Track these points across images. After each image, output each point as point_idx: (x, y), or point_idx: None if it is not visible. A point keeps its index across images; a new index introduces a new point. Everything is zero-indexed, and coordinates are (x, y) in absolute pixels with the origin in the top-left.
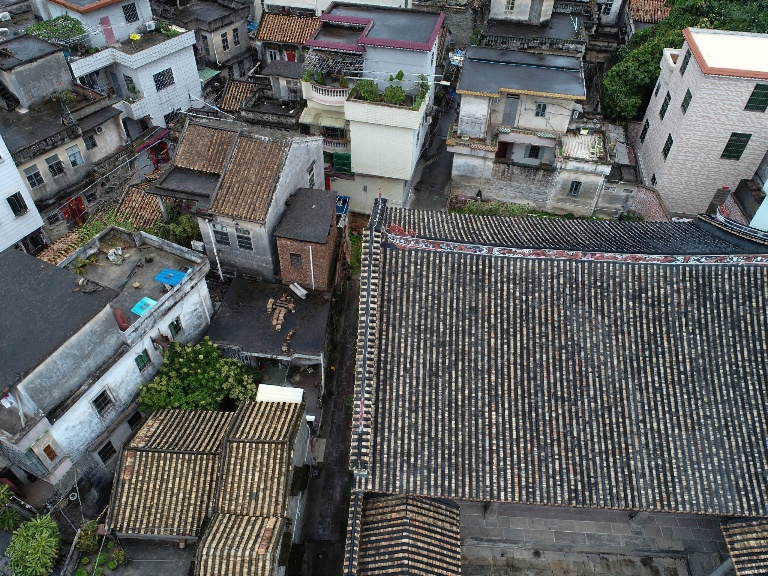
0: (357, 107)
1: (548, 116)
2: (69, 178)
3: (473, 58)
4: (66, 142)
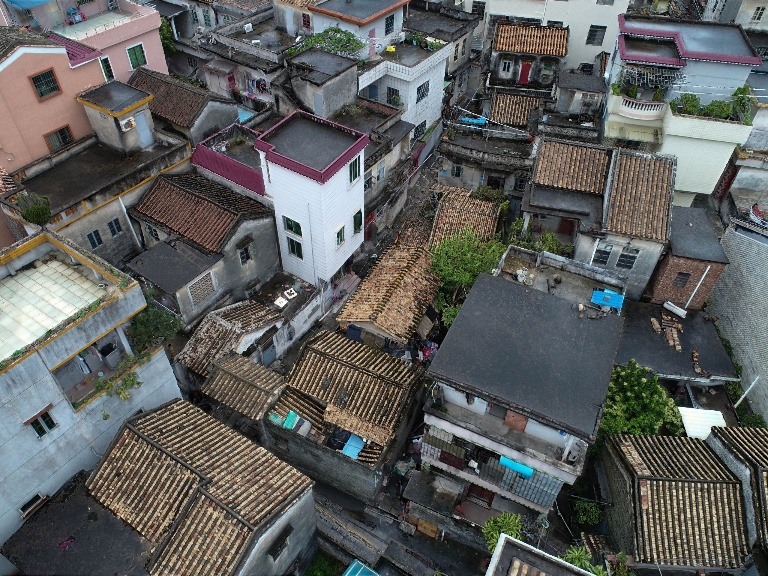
0: (684, 122)
1: None
2: (372, 193)
3: (751, 70)
4: (382, 157)
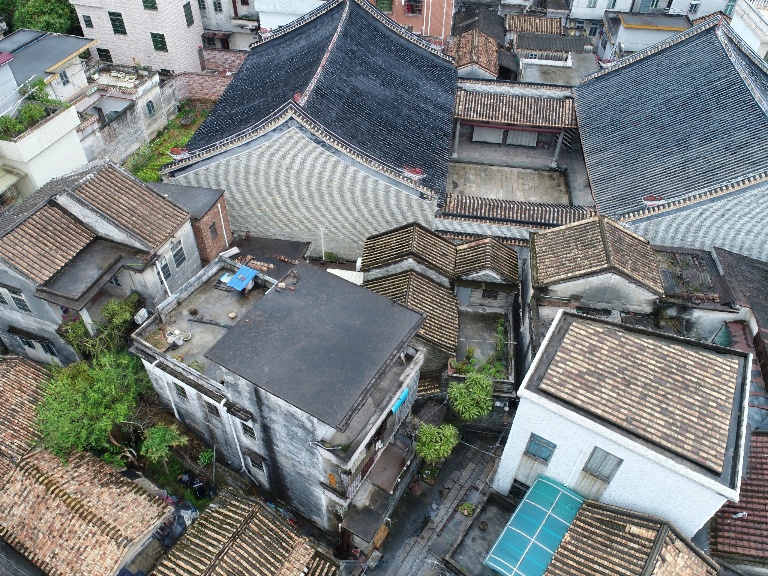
0: (29, 141)
1: (71, 80)
2: None
3: None
4: None
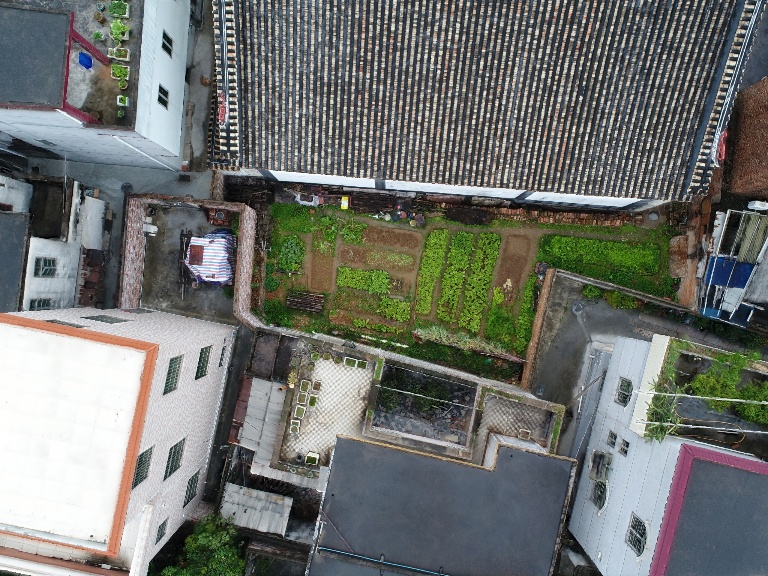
0: None
1: None
2: None
3: None
4: None
